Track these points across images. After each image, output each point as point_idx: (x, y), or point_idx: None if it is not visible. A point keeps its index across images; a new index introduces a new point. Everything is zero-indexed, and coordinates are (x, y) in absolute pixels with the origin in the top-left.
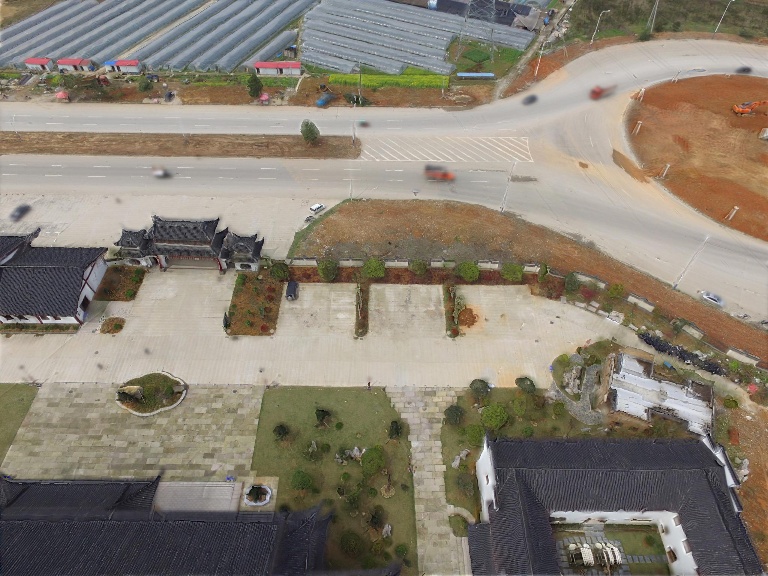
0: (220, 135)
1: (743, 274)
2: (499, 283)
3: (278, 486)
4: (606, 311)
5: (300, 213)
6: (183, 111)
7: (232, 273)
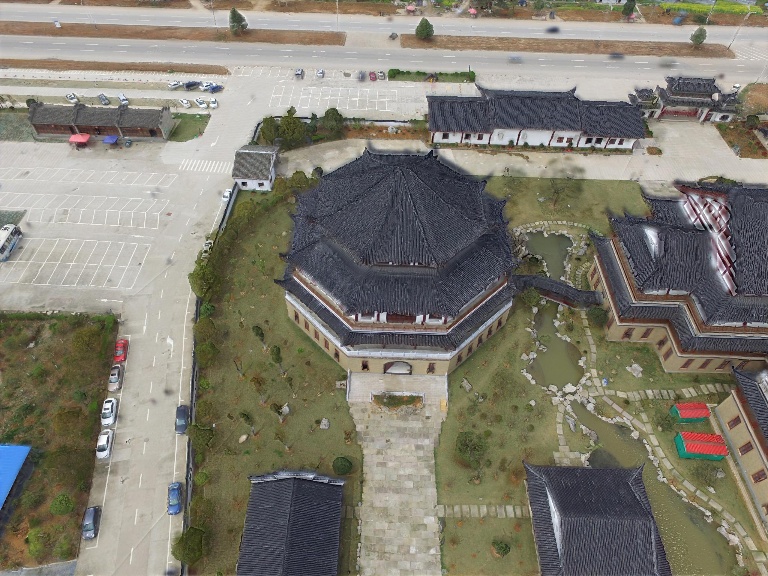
0: (616, 41)
1: None
2: None
3: None
4: None
5: (723, 91)
6: (570, 25)
7: (708, 124)
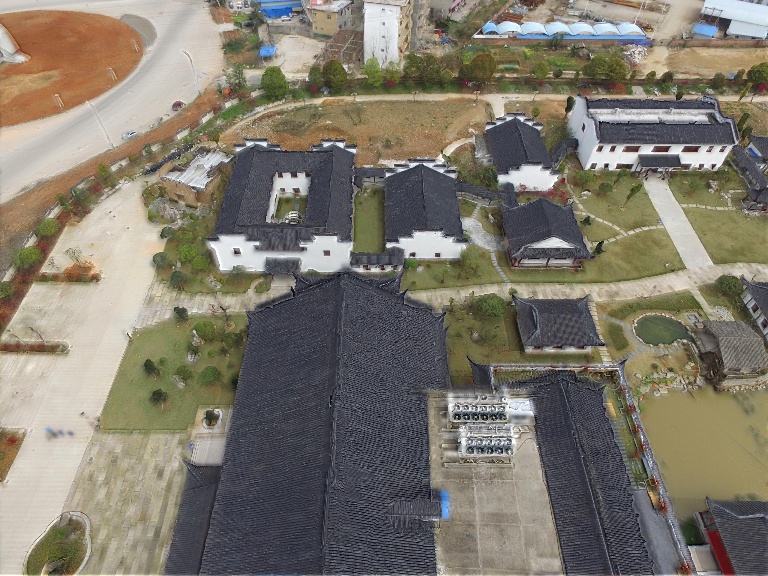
0: None
1: (117, 116)
2: (55, 241)
3: (207, 405)
4: (118, 184)
5: None
6: None
7: None
